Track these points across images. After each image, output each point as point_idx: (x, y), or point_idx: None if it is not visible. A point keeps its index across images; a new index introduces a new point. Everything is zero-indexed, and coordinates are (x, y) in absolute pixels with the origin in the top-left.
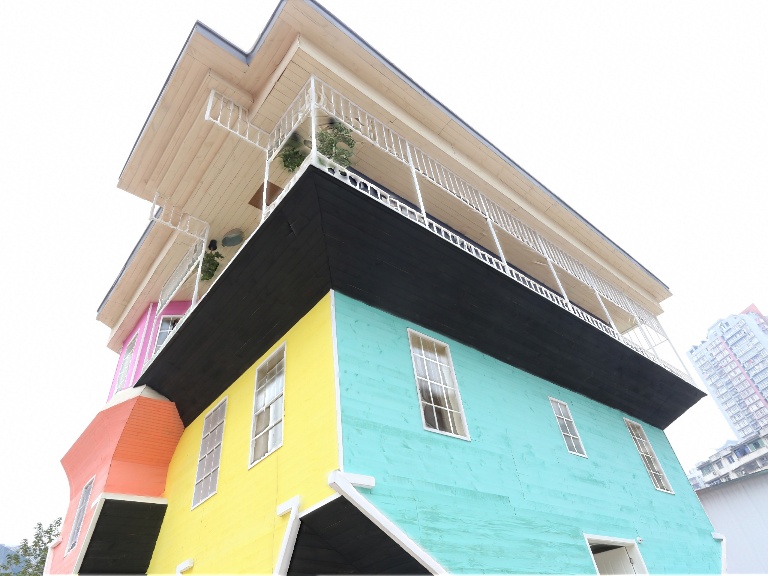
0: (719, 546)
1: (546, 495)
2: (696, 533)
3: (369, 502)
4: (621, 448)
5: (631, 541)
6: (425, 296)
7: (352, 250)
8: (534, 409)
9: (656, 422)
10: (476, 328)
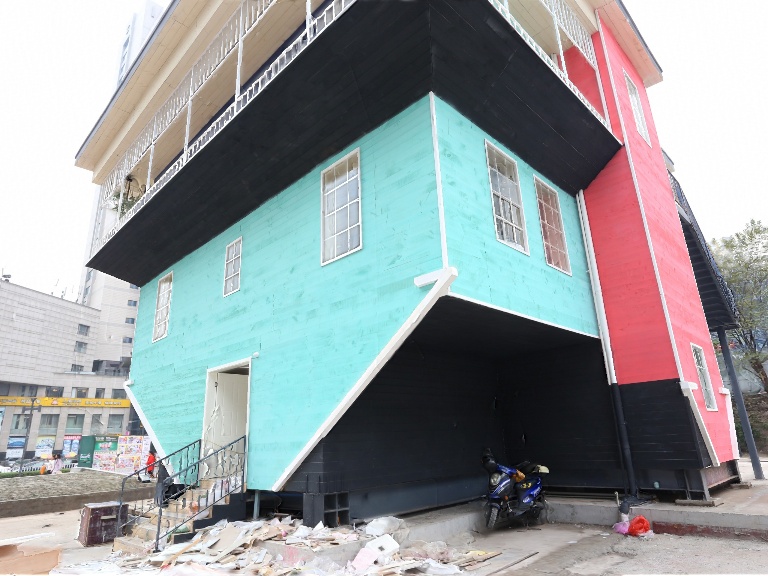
0: (423, 298)
1: (194, 350)
2: (371, 300)
3: (131, 390)
4: (292, 238)
5: (247, 359)
6: (146, 260)
7: (121, 273)
8: (210, 274)
9: (395, 105)
10: (171, 248)
